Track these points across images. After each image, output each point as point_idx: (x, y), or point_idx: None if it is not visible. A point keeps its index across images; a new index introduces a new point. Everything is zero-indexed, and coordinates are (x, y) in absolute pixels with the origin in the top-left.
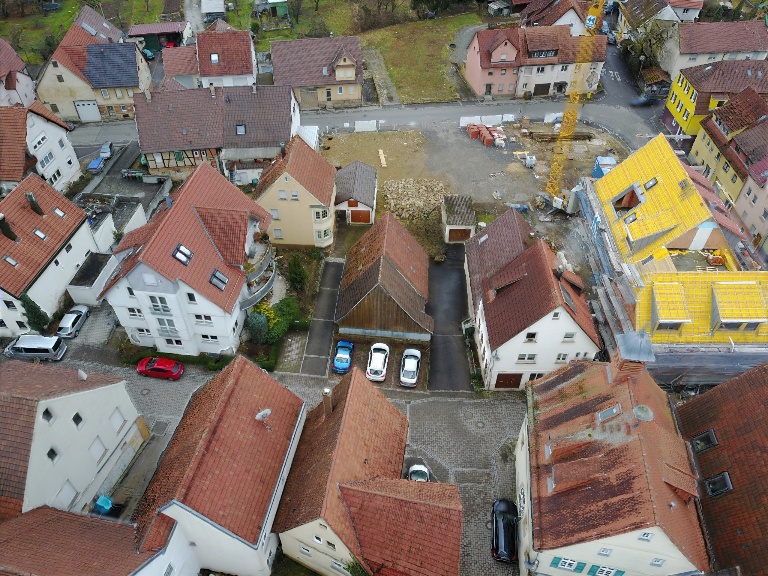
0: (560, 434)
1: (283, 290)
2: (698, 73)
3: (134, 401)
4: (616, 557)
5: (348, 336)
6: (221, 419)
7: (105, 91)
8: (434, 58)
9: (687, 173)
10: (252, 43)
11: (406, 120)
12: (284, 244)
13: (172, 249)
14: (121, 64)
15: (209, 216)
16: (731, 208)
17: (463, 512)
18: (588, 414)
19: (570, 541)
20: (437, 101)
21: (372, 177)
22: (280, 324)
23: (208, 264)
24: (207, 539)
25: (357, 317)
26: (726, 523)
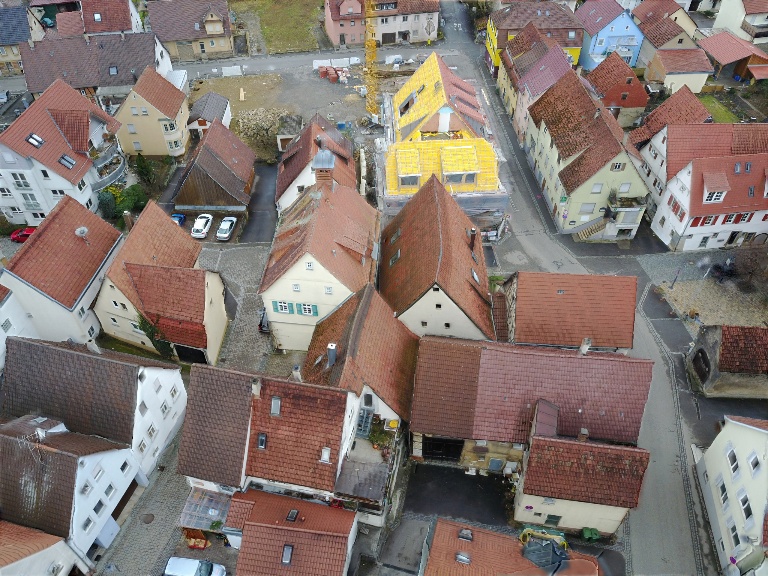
0: (282, 227)
1: (135, 183)
2: (500, 15)
3: (7, 257)
4: (304, 292)
5: (182, 211)
6: (46, 229)
7: (2, 49)
8: (304, 18)
9: (440, 76)
10: (133, 5)
11: (269, 66)
12: (144, 155)
13: (26, 136)
14: (15, 25)
15: (59, 116)
16: (514, 117)
17: (245, 309)
18: (301, 213)
19: (272, 282)
20: (299, 51)
21: (223, 104)
22: (125, 202)
23: (58, 150)
24: (37, 308)
25: (187, 195)
26: (393, 278)
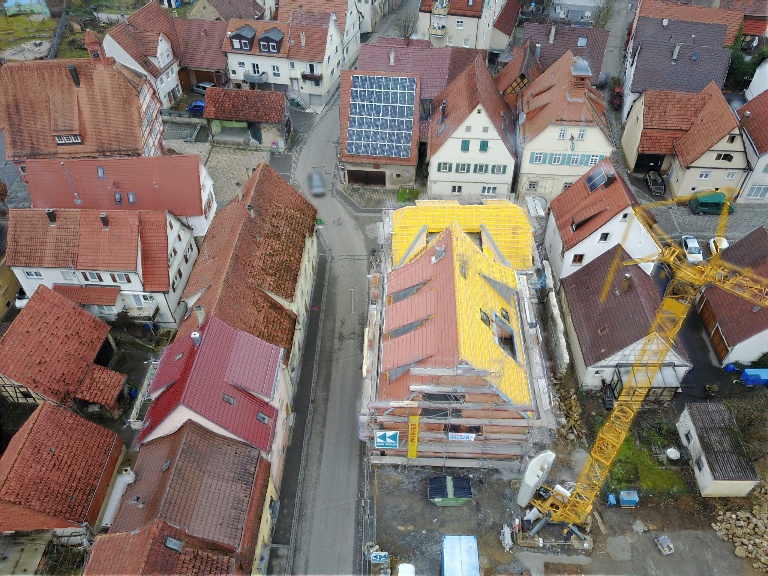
0: None
1: None
2: None
3: None
4: None
5: None
6: None
7: None
8: None
9: None
10: None
11: None
12: None
13: None
14: None
15: None
16: None
17: None
18: None
19: None
20: None
21: None
22: None
23: None
24: None
25: None
26: None
